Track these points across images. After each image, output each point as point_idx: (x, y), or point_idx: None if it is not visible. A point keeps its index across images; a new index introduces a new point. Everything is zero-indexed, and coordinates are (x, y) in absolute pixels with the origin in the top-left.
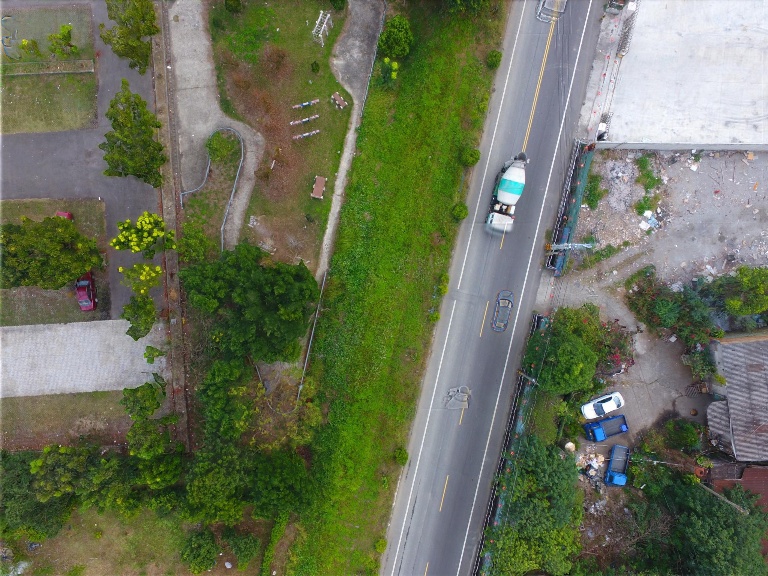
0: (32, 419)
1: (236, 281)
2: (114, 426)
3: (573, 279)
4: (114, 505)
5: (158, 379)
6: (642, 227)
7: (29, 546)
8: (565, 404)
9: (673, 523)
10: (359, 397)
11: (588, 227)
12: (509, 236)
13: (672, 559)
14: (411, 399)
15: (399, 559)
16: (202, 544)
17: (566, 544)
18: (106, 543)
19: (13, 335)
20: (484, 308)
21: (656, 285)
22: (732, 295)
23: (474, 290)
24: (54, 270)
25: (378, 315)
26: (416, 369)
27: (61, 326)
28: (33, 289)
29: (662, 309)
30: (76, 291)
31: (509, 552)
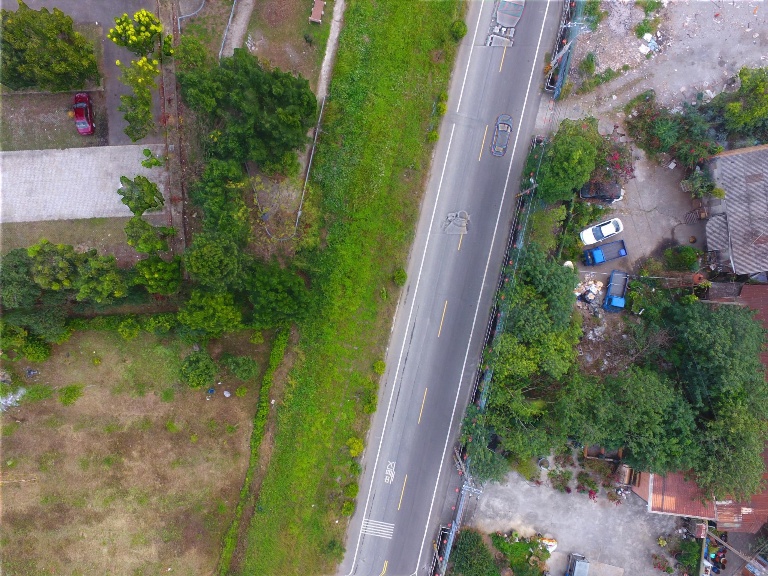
0: (30, 245)
1: (234, 85)
2: (112, 253)
3: (572, 103)
4: (112, 326)
5: (156, 192)
6: (642, 51)
7: (27, 373)
8: (564, 207)
9: (671, 334)
10: (358, 216)
11: (588, 50)
12: (508, 59)
13: (670, 377)
14: (410, 220)
15: (398, 384)
16: (200, 358)
17: (564, 348)
18: (104, 371)
19: (10, 160)
20: (483, 132)
21: (655, 109)
22: (732, 102)
23: (473, 114)
24: (51, 57)
25: (377, 133)
26: (415, 190)
27: (59, 152)
28: (30, 114)
29: (661, 128)
30: (73, 116)
31: (507, 354)
